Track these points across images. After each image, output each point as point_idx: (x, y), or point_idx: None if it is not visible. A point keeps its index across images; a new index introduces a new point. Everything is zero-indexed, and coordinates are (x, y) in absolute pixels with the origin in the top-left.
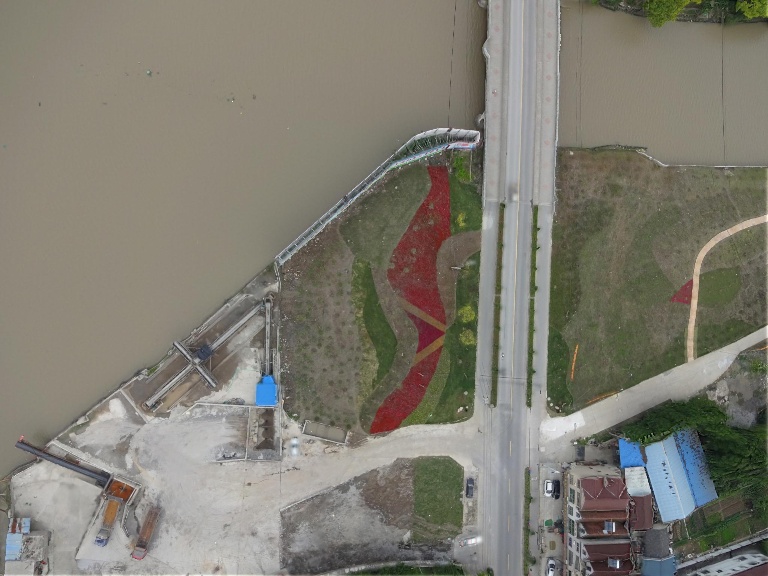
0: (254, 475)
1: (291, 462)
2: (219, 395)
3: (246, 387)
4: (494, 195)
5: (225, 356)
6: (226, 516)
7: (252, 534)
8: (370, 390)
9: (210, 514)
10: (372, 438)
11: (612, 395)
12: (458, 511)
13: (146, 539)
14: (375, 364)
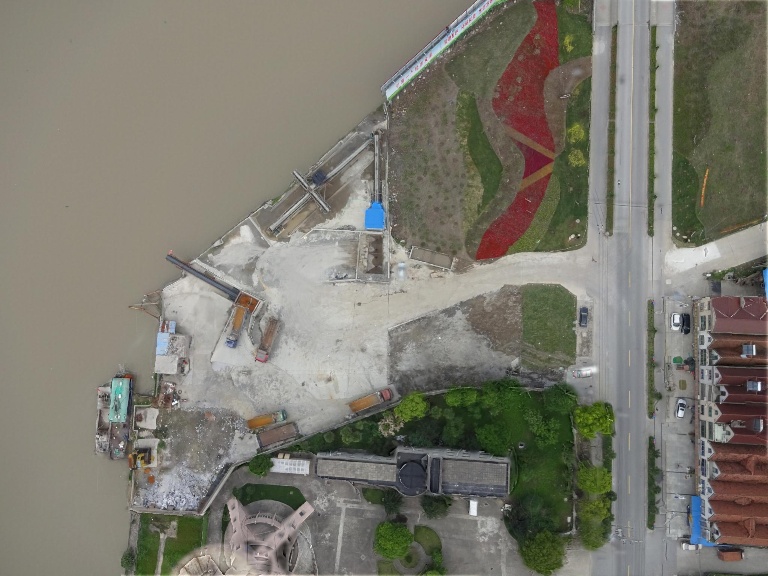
0: (364, 296)
1: (398, 285)
2: (333, 222)
3: (357, 215)
4: (605, 19)
5: (338, 187)
6: (338, 332)
7: (362, 350)
8: (475, 216)
9: (324, 329)
10: (478, 265)
11: (754, 225)
12: (571, 341)
13: (268, 346)
14: (480, 190)
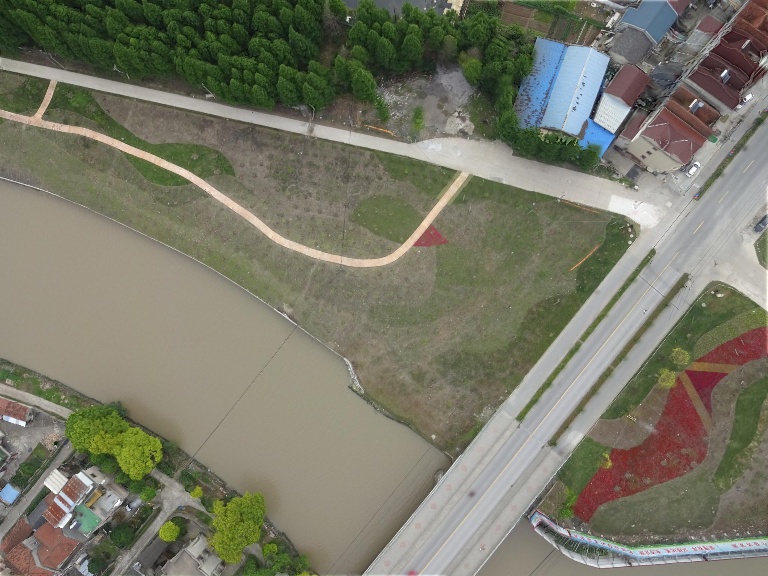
0: None
1: None
2: None
3: None
4: (551, 458)
5: None
6: None
7: None
8: None
9: None
10: None
11: None
12: None
13: None
14: None
